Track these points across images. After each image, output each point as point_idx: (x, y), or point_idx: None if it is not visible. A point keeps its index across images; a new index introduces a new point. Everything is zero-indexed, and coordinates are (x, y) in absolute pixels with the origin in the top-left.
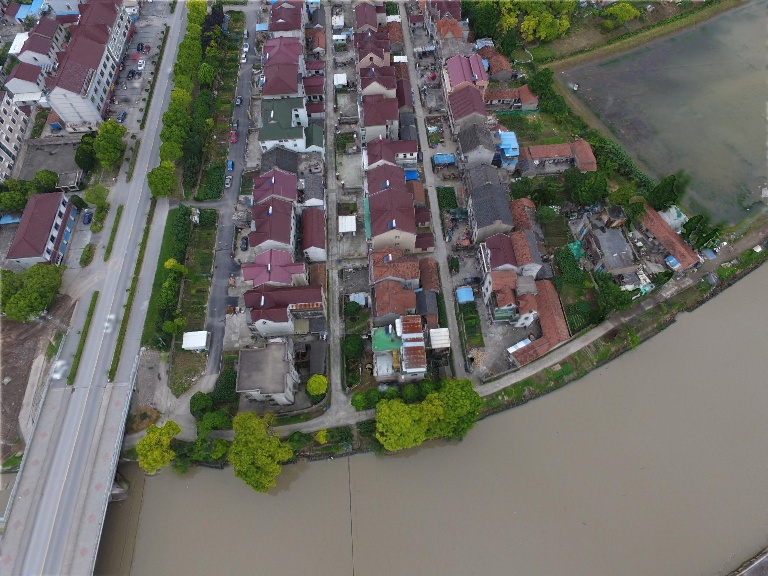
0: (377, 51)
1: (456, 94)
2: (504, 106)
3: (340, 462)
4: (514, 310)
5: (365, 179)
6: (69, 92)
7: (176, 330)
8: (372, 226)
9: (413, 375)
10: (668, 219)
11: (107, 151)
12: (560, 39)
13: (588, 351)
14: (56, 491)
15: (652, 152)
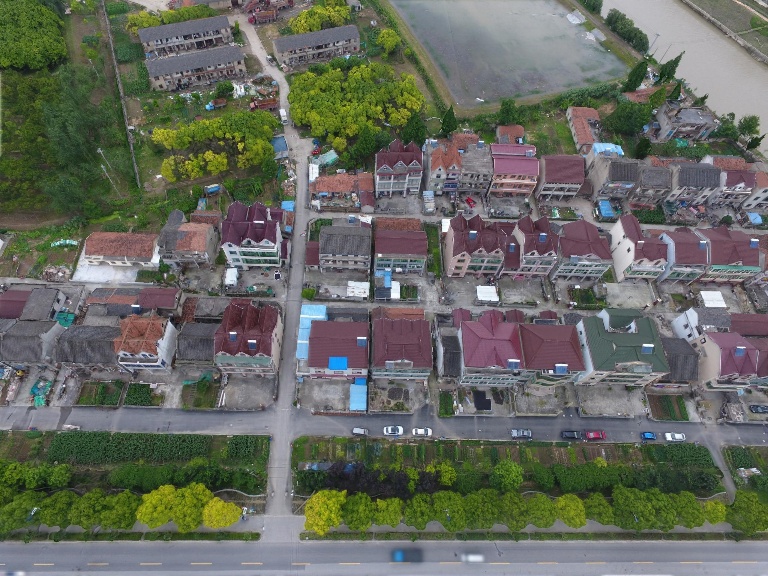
0: None
1: (549, 174)
2: None
3: None
4: None
5: None
6: None
7: None
8: (747, 264)
9: None
10: (642, 87)
11: None
12: None
13: (763, 160)
14: None
15: (559, 78)
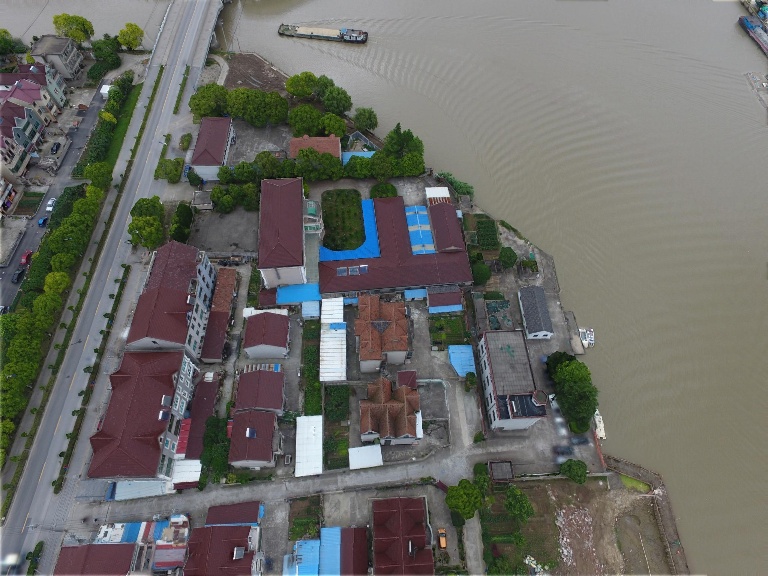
0: None
1: None
2: None
3: None
4: None
5: None
6: None
7: None
8: None
9: None
10: None
11: None
12: None
13: None
14: (191, 30)
15: None
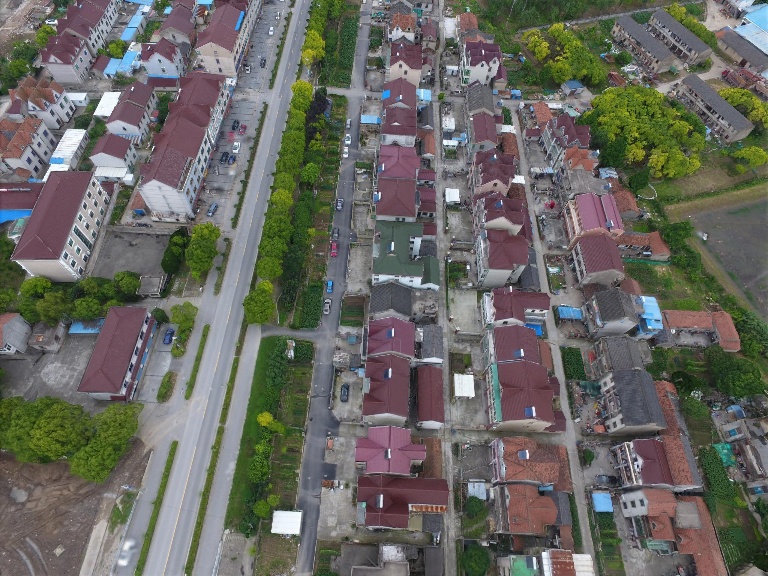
0: (503, 177)
1: (589, 240)
2: (630, 251)
3: None
4: (671, 544)
5: (489, 335)
6: (165, 185)
7: None
8: (503, 405)
9: None
10: None
11: (200, 260)
12: (685, 176)
13: None
14: None
15: None
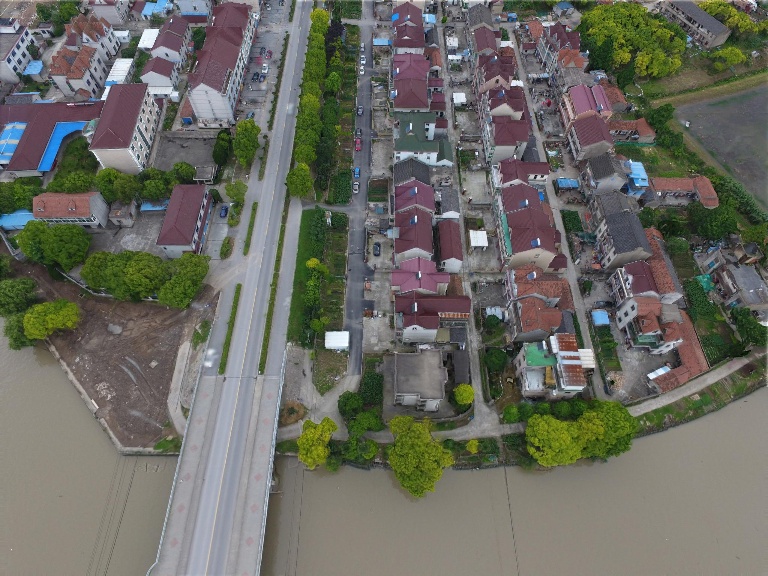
0: (504, 74)
1: (582, 122)
2: (620, 137)
3: (486, 473)
4: (658, 337)
5: (498, 196)
6: (211, 89)
7: (321, 328)
8: (513, 243)
9: (565, 393)
10: None
11: (246, 149)
12: (669, 77)
13: (725, 384)
14: (217, 478)
15: None
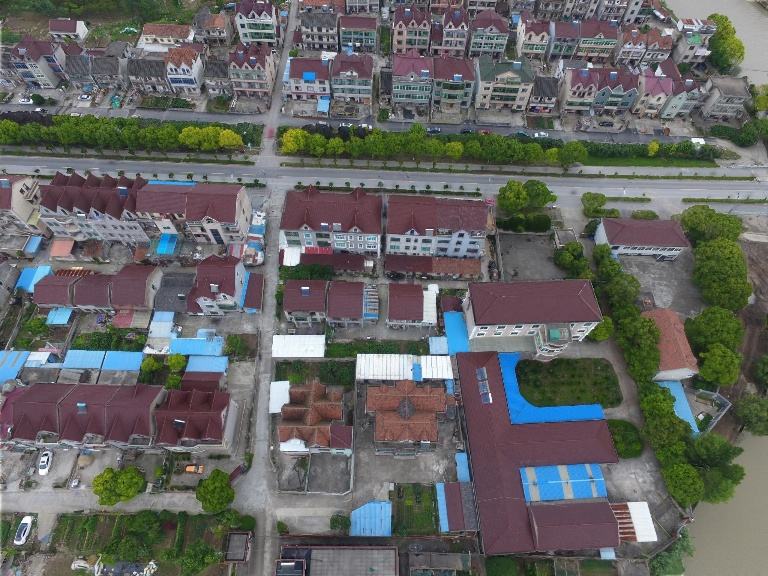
0: None
1: None
2: None
3: None
4: None
5: None
6: None
7: None
8: (608, 38)
9: None
10: None
11: None
12: None
13: None
14: None
15: None
